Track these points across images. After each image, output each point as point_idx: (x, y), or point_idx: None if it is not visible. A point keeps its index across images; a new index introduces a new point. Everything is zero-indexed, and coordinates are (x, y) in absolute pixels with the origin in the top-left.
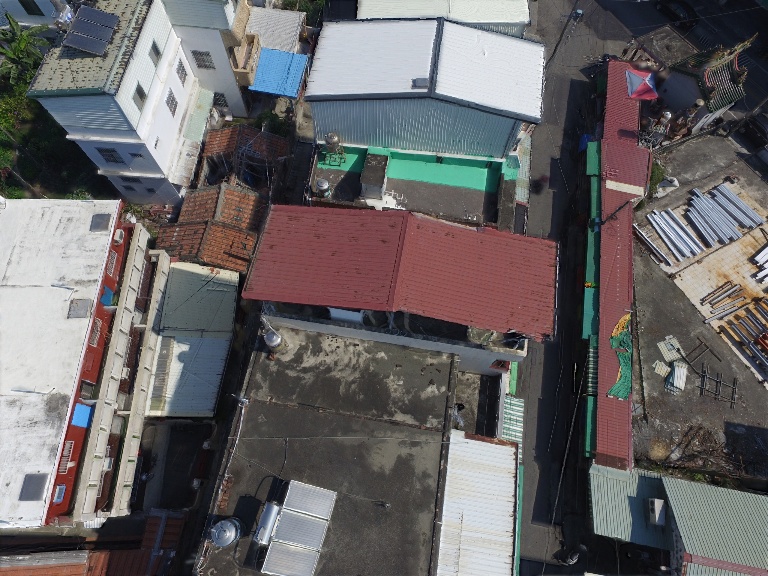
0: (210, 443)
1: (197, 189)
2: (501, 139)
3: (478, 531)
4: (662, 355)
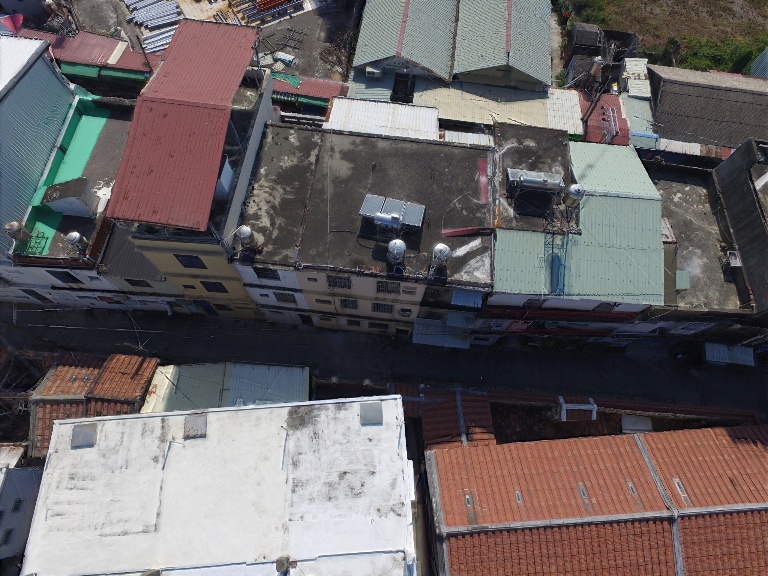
0: (333, 377)
1: (30, 438)
2: (55, 85)
3: (388, 119)
4: (268, 64)
